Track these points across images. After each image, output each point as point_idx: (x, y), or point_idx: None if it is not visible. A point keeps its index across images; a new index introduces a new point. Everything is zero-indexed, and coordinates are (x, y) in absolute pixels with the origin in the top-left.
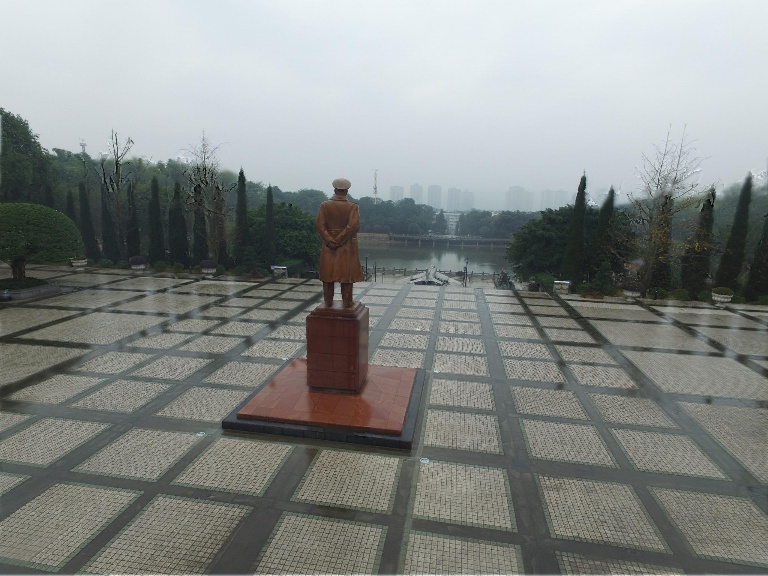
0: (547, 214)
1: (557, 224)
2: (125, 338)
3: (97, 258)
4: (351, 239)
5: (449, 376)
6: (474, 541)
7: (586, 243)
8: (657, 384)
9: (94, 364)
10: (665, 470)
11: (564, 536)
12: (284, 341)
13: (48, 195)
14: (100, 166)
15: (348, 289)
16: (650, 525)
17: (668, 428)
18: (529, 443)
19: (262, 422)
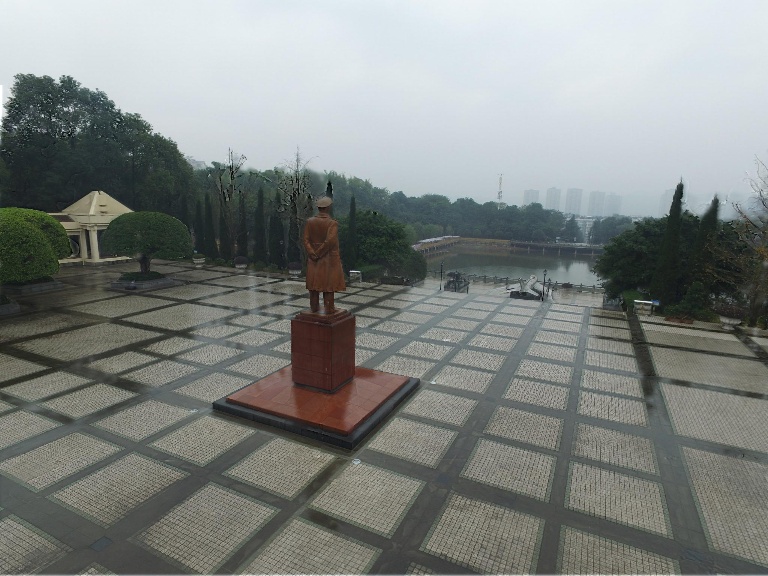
0: (641, 225)
1: (653, 237)
2: (193, 326)
3: (216, 257)
4: (331, 252)
5: (442, 388)
6: (344, 537)
7: (685, 259)
8: (674, 424)
9: (158, 346)
10: (599, 513)
11: (432, 551)
12: None
13: (184, 203)
14: (218, 179)
15: (328, 297)
16: (531, 561)
17: (643, 472)
18: (470, 462)
19: (242, 408)
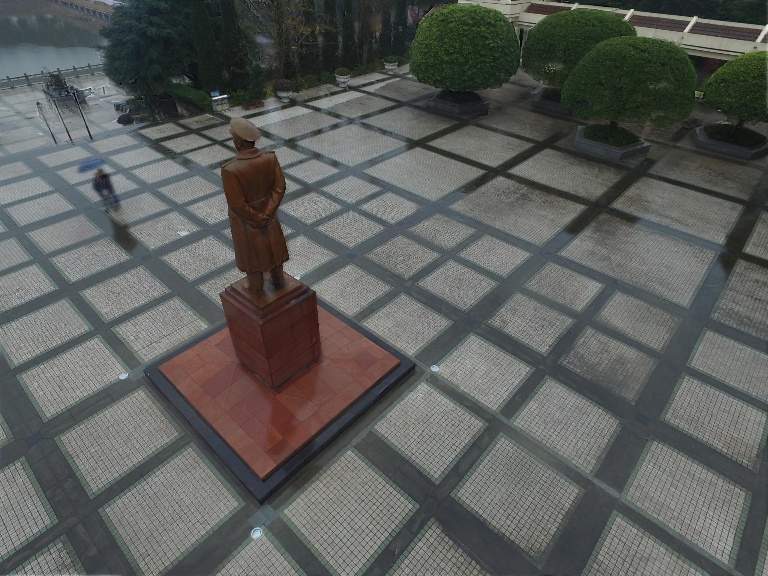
0: (146, 1)
1: (163, 14)
2: None
3: None
4: None
5: (314, 276)
6: (535, 394)
7: None
8: (423, 196)
9: None
10: (512, 268)
11: (547, 351)
12: (60, 353)
13: None
14: None
15: None
16: (553, 311)
17: (474, 234)
18: (450, 301)
19: (295, 460)
